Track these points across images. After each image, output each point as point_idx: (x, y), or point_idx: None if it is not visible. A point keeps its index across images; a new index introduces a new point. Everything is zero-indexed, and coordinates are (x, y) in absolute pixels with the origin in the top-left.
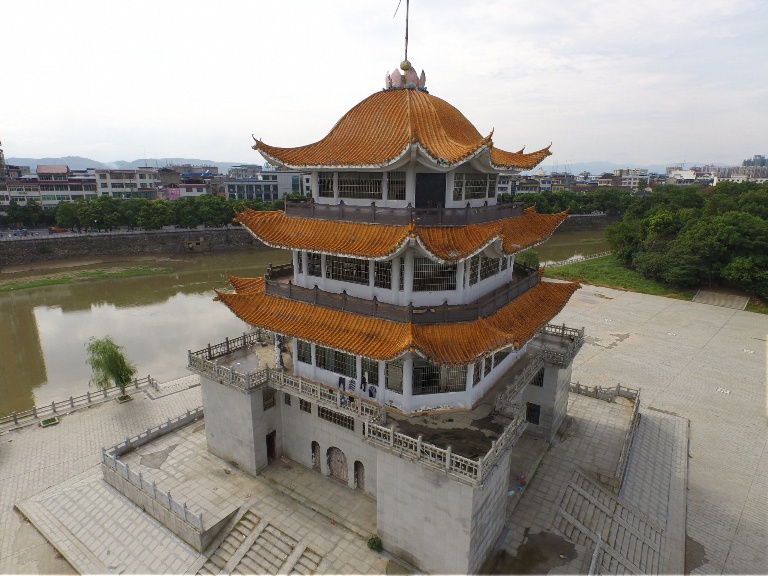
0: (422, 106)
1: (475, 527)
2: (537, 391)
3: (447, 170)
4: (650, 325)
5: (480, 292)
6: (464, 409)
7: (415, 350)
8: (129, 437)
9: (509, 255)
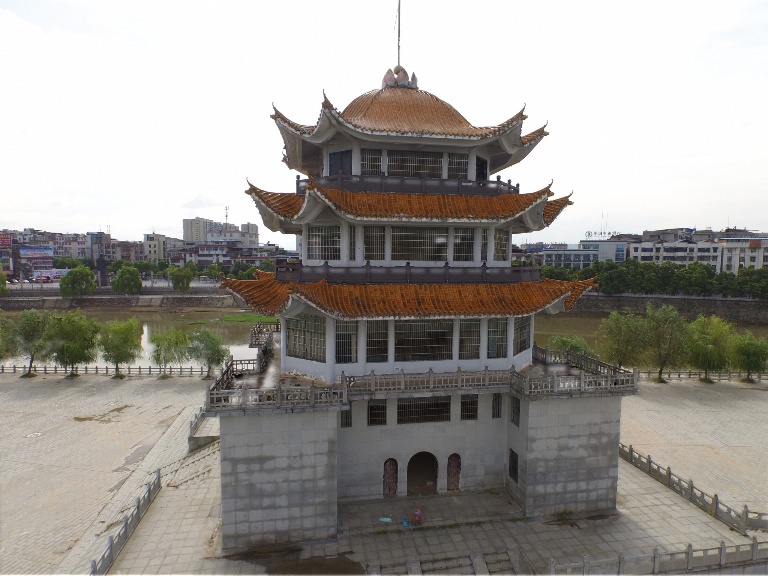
0: (366, 97)
1: (233, 475)
2: (516, 433)
3: (321, 141)
4: None
5: None
6: (324, 383)
7: (227, 288)
8: None
9: (364, 218)
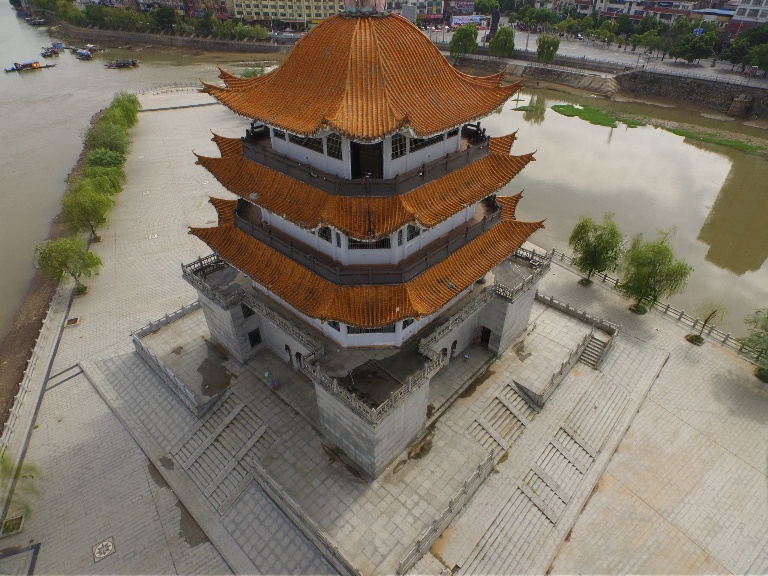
0: None
1: None
2: None
3: None
4: None
5: (286, 228)
6: None
7: None
8: None
9: None
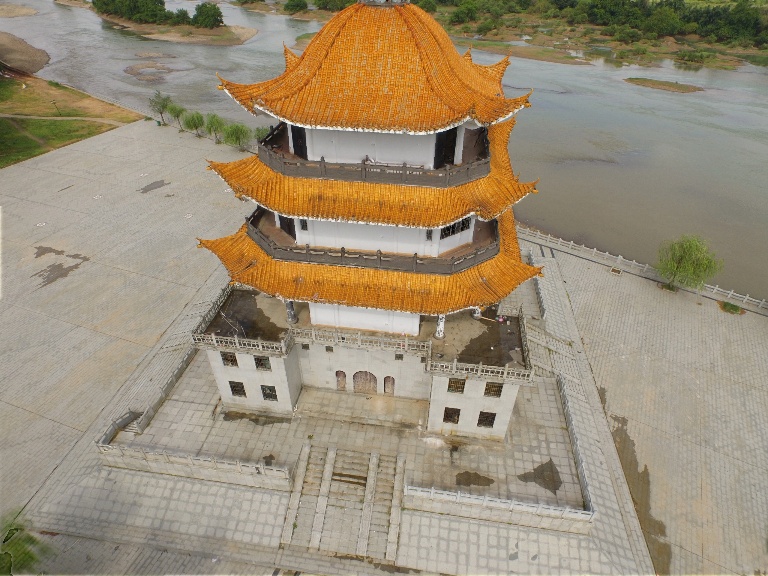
0: None
1: None
2: None
3: None
4: (4, 233)
5: None
6: None
7: None
8: None
9: None
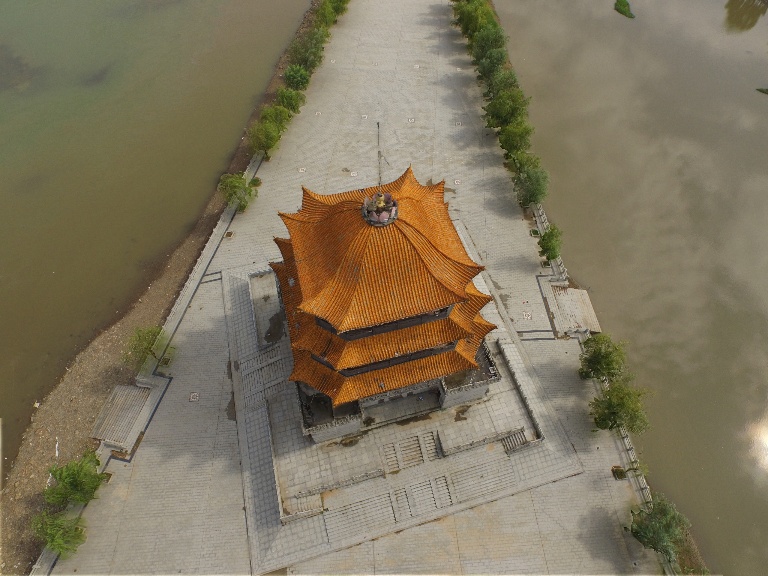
0: (341, 207)
1: None
2: None
3: None
4: None
5: None
6: None
7: None
8: (494, 258)
9: None
